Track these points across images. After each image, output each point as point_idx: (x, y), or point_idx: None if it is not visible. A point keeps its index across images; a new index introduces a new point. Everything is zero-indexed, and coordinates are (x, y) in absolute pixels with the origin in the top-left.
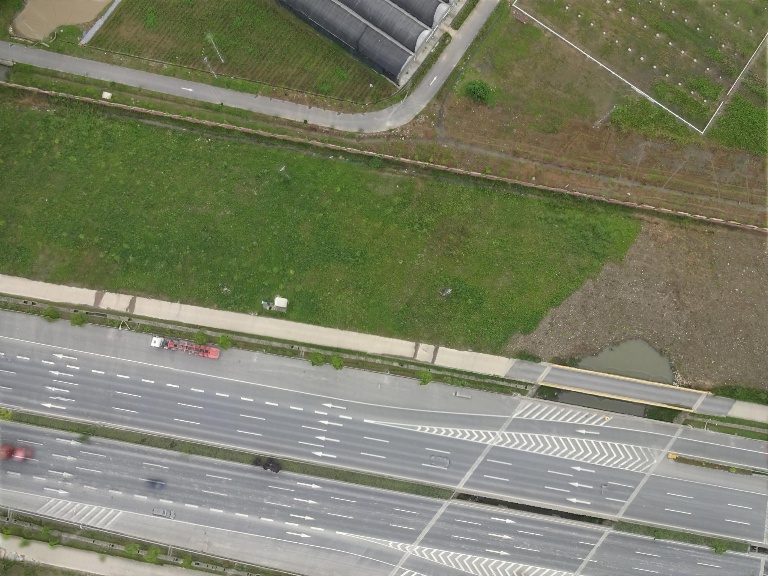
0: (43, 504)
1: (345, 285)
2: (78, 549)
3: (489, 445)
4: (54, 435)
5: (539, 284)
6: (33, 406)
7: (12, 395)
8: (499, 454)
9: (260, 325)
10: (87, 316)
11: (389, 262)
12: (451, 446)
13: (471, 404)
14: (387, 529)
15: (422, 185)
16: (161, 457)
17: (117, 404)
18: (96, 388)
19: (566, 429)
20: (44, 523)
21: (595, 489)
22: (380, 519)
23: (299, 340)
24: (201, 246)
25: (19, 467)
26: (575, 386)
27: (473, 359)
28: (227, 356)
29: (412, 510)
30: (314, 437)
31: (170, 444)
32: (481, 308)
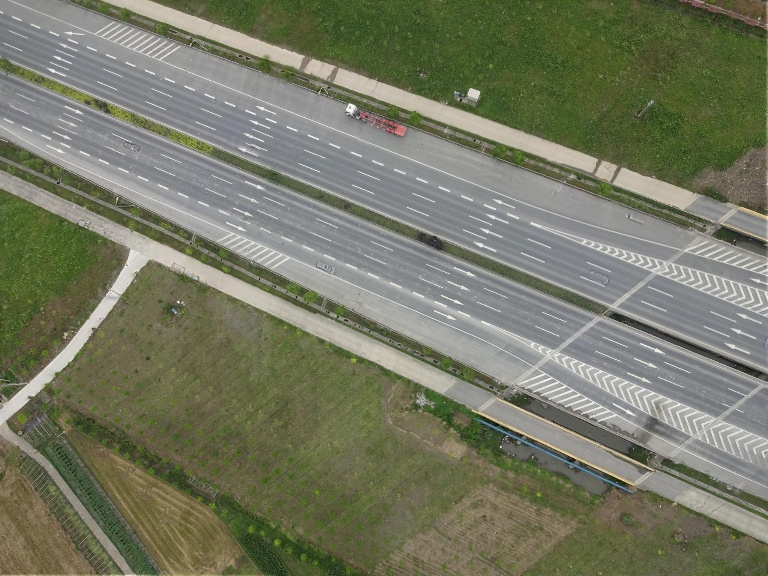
0: (223, 236)
1: (539, 89)
2: (245, 282)
3: (653, 273)
4: (244, 177)
5: (745, 120)
6: (231, 148)
7: (215, 135)
8: (662, 284)
9: (448, 114)
10: (292, 77)
11: (589, 74)
12: (613, 265)
13: (643, 229)
14: (532, 330)
15: (637, 7)
16: (333, 217)
17: (303, 161)
18: (288, 143)
19: (739, 275)
20: (222, 251)
21: (758, 340)
22: (527, 319)
23: (482, 135)
24: (409, 28)
25: (209, 199)
26: (759, 234)
27: (655, 186)
28: (411, 137)
29: (561, 317)
30: (479, 228)
31: (344, 205)
32: (676, 134)
